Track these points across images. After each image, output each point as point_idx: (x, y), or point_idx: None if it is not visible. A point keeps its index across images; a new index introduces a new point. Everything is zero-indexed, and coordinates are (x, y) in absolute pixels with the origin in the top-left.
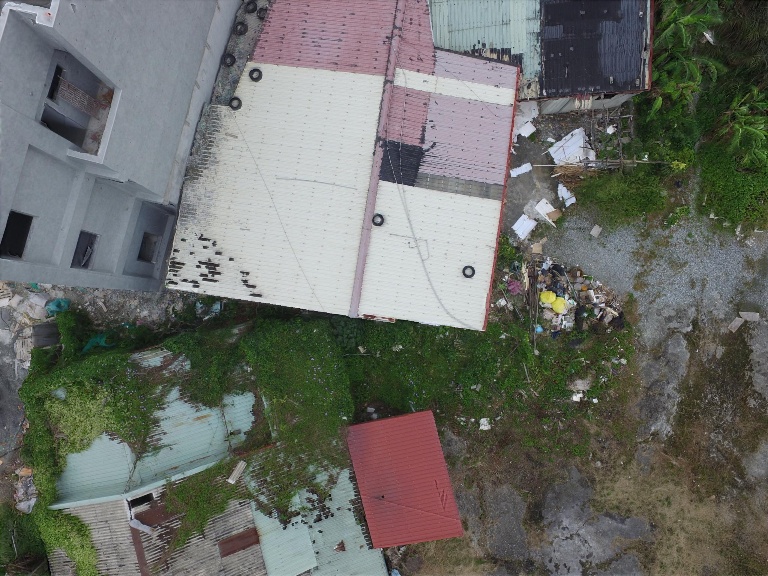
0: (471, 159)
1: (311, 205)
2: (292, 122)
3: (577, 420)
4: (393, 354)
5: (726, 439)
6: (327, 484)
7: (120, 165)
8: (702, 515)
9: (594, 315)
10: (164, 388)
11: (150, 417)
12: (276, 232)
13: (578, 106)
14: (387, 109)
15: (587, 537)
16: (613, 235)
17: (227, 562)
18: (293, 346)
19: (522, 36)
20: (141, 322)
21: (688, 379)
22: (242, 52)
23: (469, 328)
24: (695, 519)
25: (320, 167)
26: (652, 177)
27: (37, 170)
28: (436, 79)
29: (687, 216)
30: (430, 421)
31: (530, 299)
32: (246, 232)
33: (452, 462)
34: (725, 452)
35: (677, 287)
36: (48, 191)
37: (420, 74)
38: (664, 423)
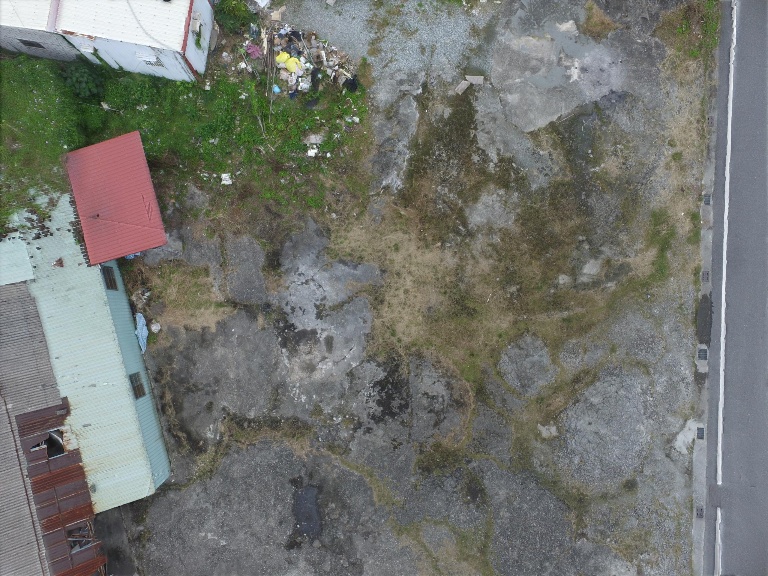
0: None
1: None
2: None
3: (313, 175)
4: (136, 112)
5: (452, 192)
6: (47, 206)
7: None
8: (428, 261)
9: (326, 75)
10: None
11: None
12: None
13: None
14: None
15: (321, 282)
16: (348, 4)
17: None
18: (14, 78)
19: None
20: None
21: (417, 137)
22: None
23: (168, 48)
24: (421, 264)
25: None
26: None
27: None
28: None
29: None
30: (137, 140)
31: (268, 61)
32: None
33: (194, 214)
34: (451, 204)
35: (408, 53)
36: None
37: None
38: (394, 177)
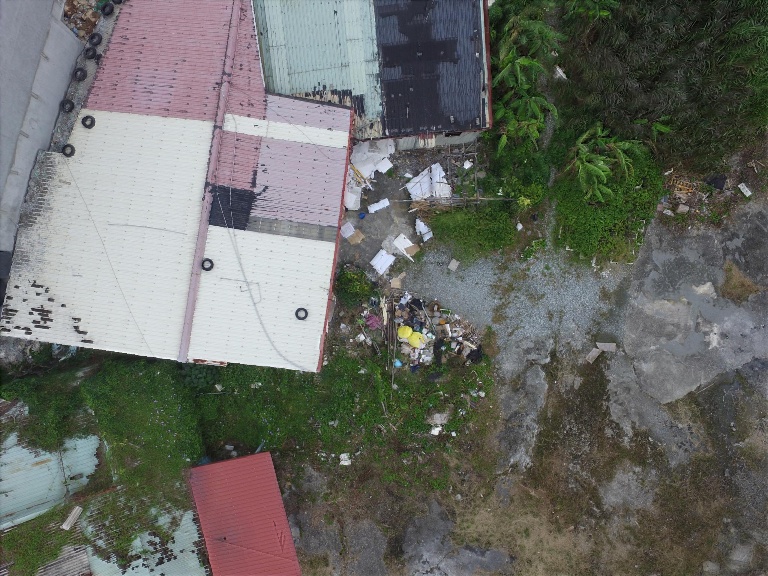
0: (304, 202)
1: (142, 251)
2: (124, 168)
3: (436, 453)
4: (251, 391)
5: (585, 470)
6: (170, 527)
7: None
8: (561, 546)
9: (451, 349)
10: (0, 435)
11: None
12: (108, 278)
13: (422, 145)
14: (217, 154)
15: (447, 571)
16: (471, 269)
17: None
18: (135, 389)
19: (362, 77)
20: None
21: (546, 410)
22: (81, 98)
23: (303, 370)
24: (554, 550)
25: (151, 213)
26: (499, 213)
27: None
28: (267, 123)
29: (544, 249)
30: (268, 462)
31: (388, 334)
32: (78, 278)
33: (312, 498)
34: (584, 483)
35: (535, 319)
36: None
37: (251, 119)
38: (523, 455)
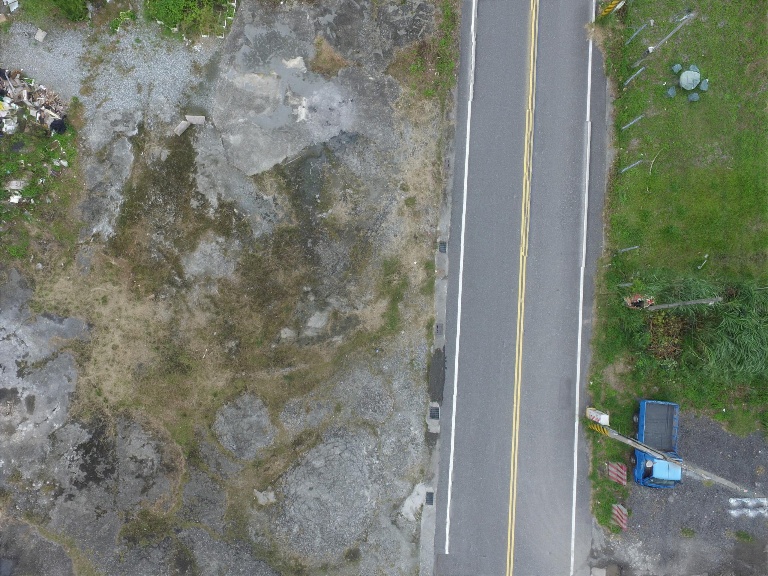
0: None
1: None
2: None
3: (17, 222)
4: None
5: (168, 240)
6: None
7: None
8: (140, 314)
9: (30, 116)
10: None
11: None
12: None
13: None
14: None
15: (24, 337)
16: (59, 40)
17: None
18: None
19: None
20: None
21: (132, 181)
22: None
23: None
24: (132, 317)
25: None
26: None
27: None
28: None
29: (134, 21)
30: None
31: None
32: None
33: None
34: (166, 252)
35: (123, 91)
36: None
37: None
38: (106, 225)
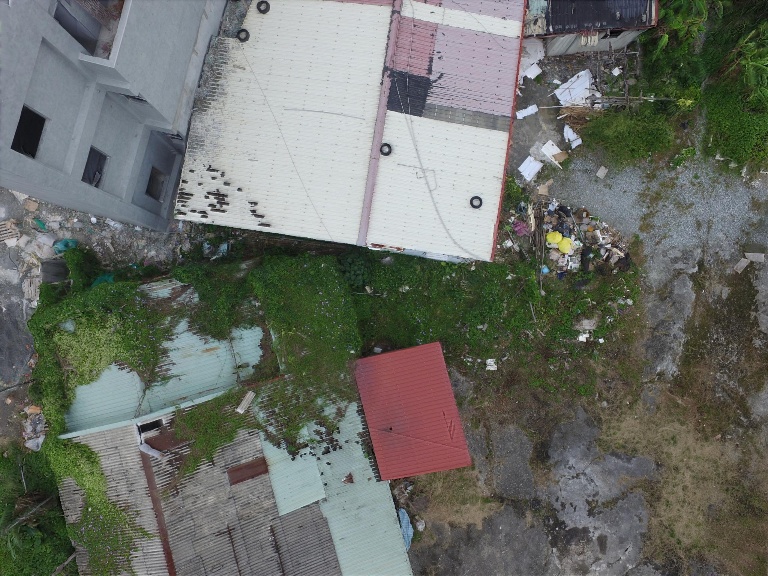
0: (478, 90)
1: (319, 135)
2: (300, 53)
3: (583, 360)
4: (400, 294)
5: (732, 379)
6: (335, 417)
7: (131, 75)
8: (708, 454)
9: (600, 255)
10: (173, 319)
11: (159, 347)
12: (284, 162)
13: (584, 43)
14: (395, 39)
15: (593, 476)
16: (619, 177)
17: (236, 490)
18: (301, 280)
19: None
20: (148, 263)
21: (694, 320)
22: None
23: (477, 258)
24: (701, 458)
25: (328, 97)
26: (658, 115)
27: (50, 69)
28: (443, 10)
29: (693, 157)
30: (438, 352)
31: (536, 240)
32: (254, 163)
33: (459, 402)
34: (731, 392)
35: (683, 228)
36: (60, 95)
37: (427, 5)
38: (670, 363)
